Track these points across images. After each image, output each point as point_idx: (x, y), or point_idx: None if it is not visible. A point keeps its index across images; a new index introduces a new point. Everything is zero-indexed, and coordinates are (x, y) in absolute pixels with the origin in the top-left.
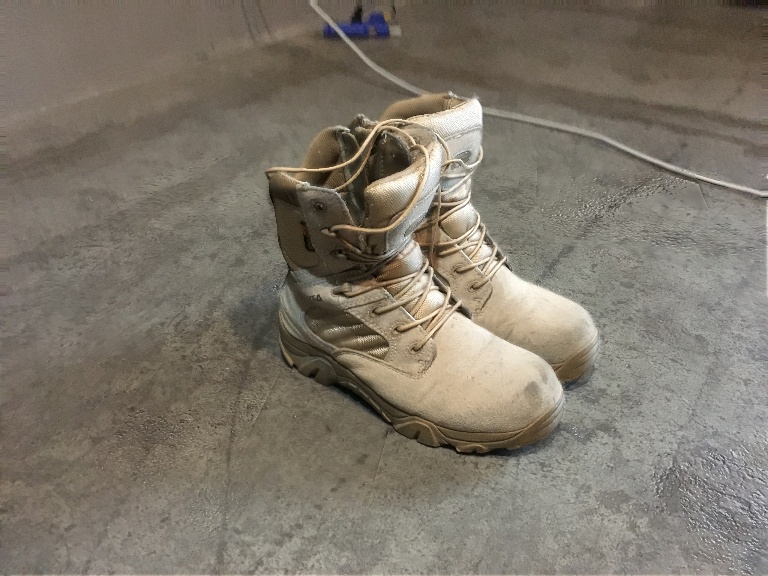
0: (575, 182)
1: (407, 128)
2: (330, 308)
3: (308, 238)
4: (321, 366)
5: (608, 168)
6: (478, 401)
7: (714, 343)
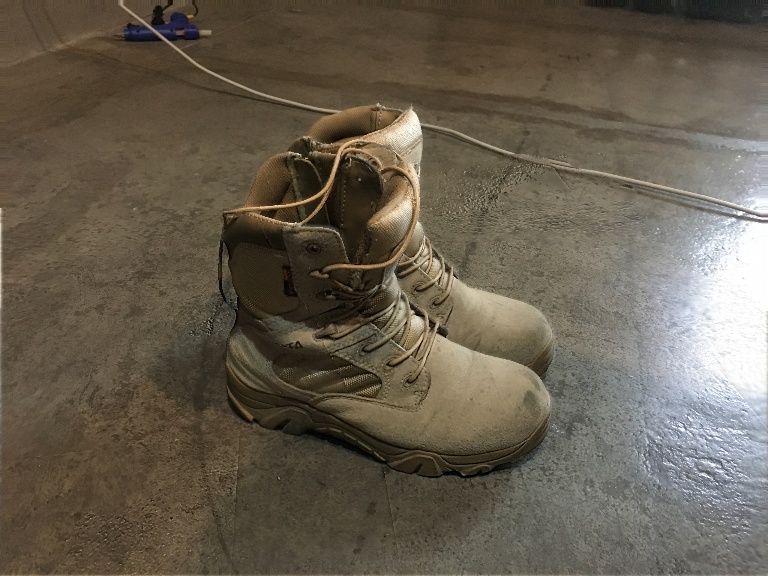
0: (448, 177)
1: (365, 148)
2: (311, 354)
3: (290, 283)
4: (293, 416)
5: (471, 160)
6: (483, 422)
7: (631, 317)
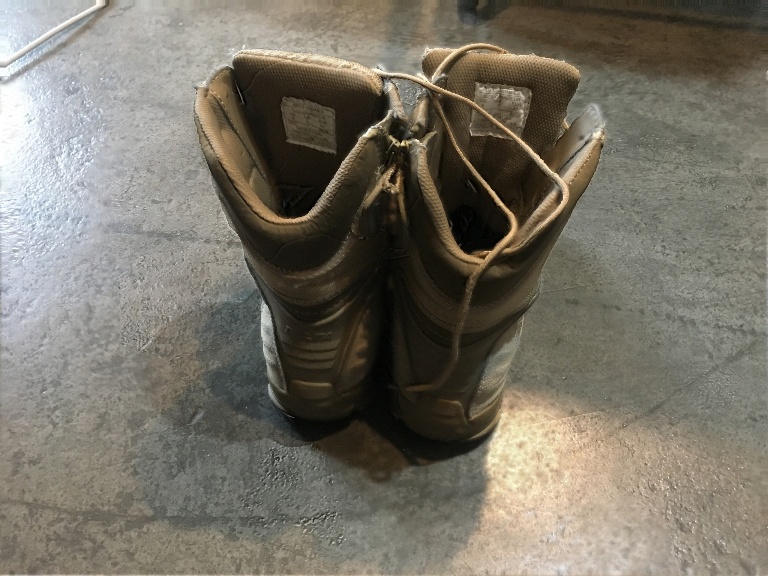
0: None
1: None
2: None
3: None
4: None
5: None
6: None
7: None
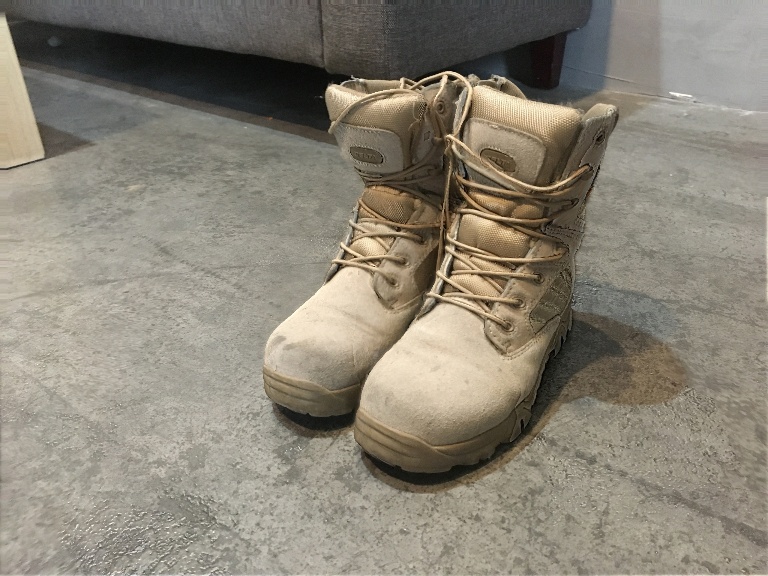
0: None
1: None
2: None
3: None
4: None
5: None
6: None
7: None
